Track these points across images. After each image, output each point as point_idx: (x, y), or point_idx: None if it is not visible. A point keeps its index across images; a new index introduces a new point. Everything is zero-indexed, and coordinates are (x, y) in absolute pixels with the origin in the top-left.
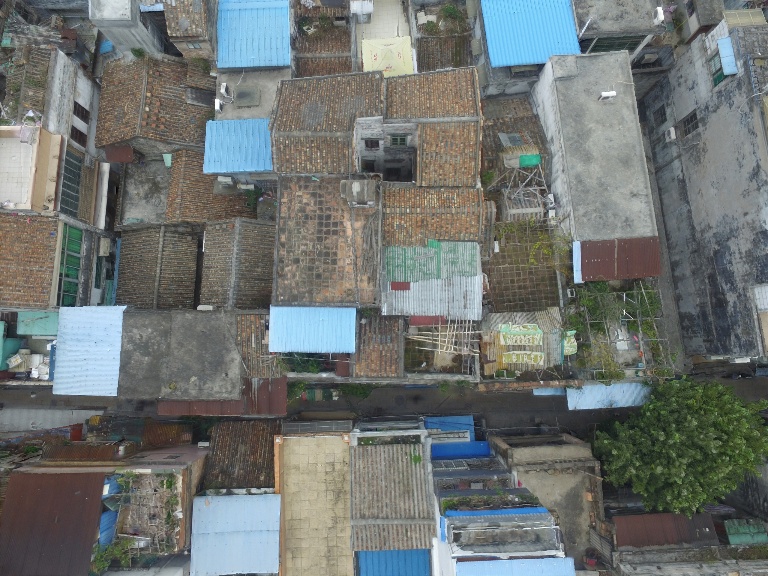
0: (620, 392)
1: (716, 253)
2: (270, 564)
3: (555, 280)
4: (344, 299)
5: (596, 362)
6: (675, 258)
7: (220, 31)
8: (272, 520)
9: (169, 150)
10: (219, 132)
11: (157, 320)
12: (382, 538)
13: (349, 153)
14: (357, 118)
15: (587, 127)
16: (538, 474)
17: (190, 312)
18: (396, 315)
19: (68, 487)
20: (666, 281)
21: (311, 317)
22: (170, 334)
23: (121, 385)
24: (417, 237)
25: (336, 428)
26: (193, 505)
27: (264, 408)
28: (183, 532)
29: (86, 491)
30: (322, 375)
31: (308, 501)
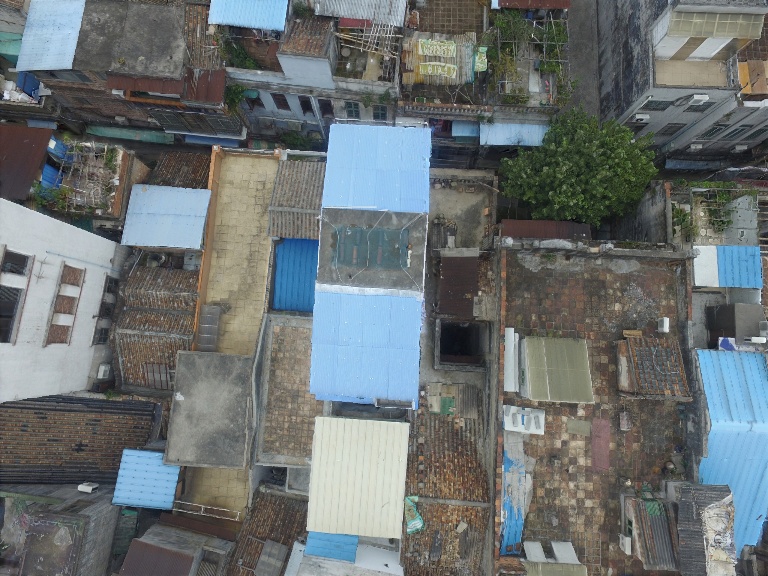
0: (528, 132)
1: (630, 18)
2: (193, 242)
3: (481, 28)
4: None
5: (501, 73)
6: (602, 49)
7: None
8: (200, 208)
9: None
10: None
11: (115, 7)
12: (295, 226)
13: None
14: None
15: None
16: (444, 191)
17: None
18: (327, 16)
19: (19, 136)
20: (592, 73)
21: None
22: (125, 20)
23: (76, 58)
24: None
25: (271, 154)
26: (131, 190)
27: (202, 95)
28: (119, 205)
29: (34, 140)
30: (257, 72)
31: (237, 211)
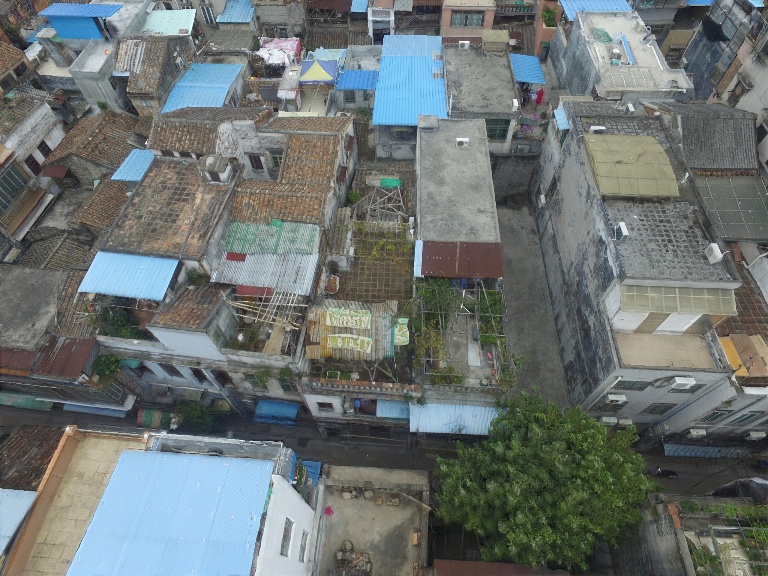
0: (471, 416)
1: (578, 284)
2: None
3: (410, 294)
4: (169, 250)
5: (424, 349)
6: (556, 311)
7: (170, 97)
8: (10, 523)
9: (99, 176)
10: (139, 156)
11: None
12: None
13: (213, 137)
14: (233, 122)
15: (443, 162)
16: (356, 502)
17: (31, 268)
18: (224, 283)
19: None
20: (550, 336)
21: (132, 264)
22: (0, 284)
23: None
24: (262, 215)
25: None
26: None
27: (57, 368)
28: None
29: None
30: (133, 342)
31: (75, 521)
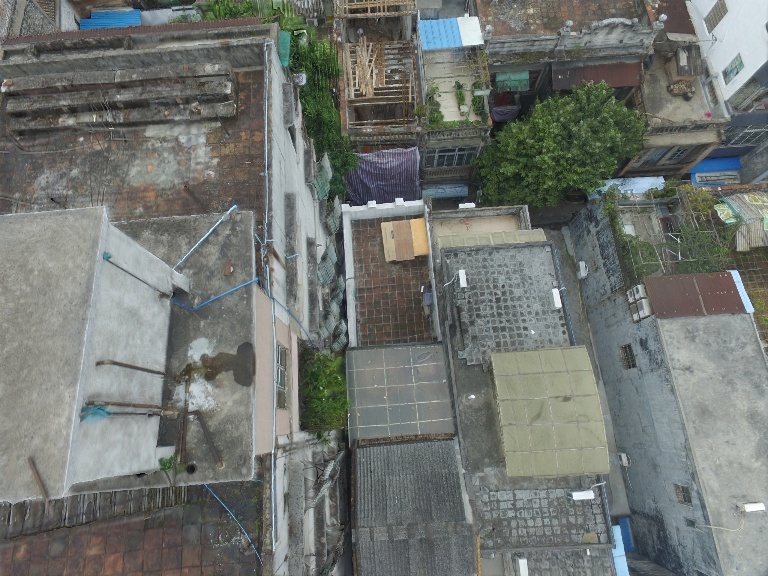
0: None
1: None
2: None
3: None
4: None
5: None
6: None
7: None
8: None
9: None
10: None
11: None
12: None
13: None
14: None
15: (763, 462)
16: None
17: None
18: None
19: None
20: None
21: None
22: None
23: None
24: None
25: None
26: None
27: None
28: None
29: None
30: None
31: None
